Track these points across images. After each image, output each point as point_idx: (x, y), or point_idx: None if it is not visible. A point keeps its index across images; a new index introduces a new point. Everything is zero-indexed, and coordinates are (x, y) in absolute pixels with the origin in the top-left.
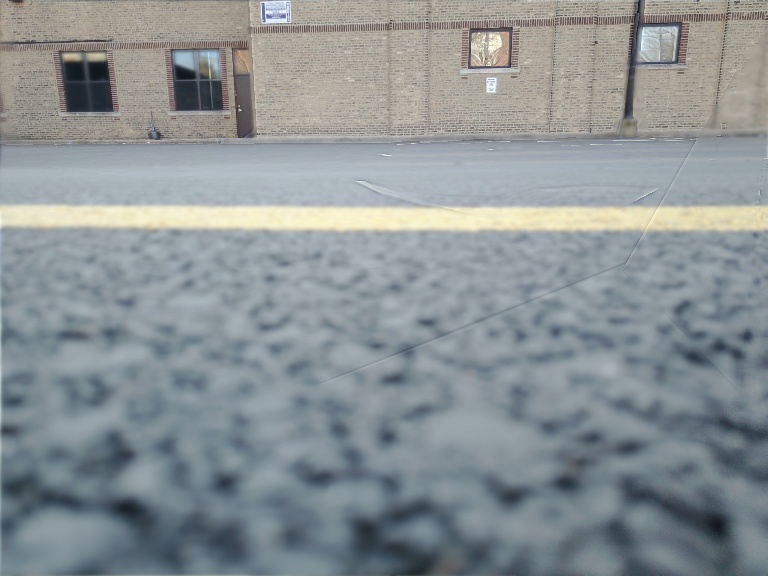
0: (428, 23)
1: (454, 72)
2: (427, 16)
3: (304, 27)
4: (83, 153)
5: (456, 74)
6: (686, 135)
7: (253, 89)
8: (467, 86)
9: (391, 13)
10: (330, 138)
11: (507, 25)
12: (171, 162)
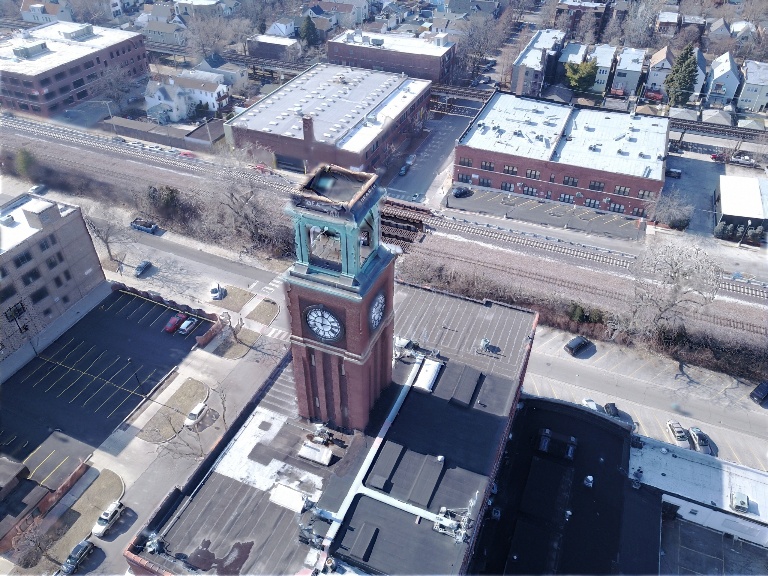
0: None
1: None
2: None
3: None
4: None
5: None
6: (43, 348)
7: None
8: None
9: None
10: None
11: None
12: (44, 406)
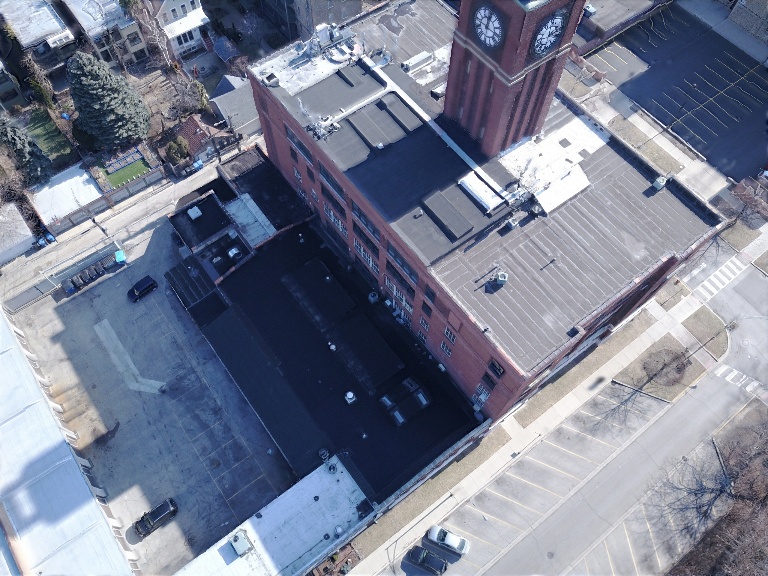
0: (765, 20)
1: (764, 30)
2: (765, 19)
3: (746, 7)
4: None
5: (764, 30)
6: None
7: (732, 11)
8: (765, 33)
9: (760, 15)
10: (728, 37)
11: None
12: (686, 63)
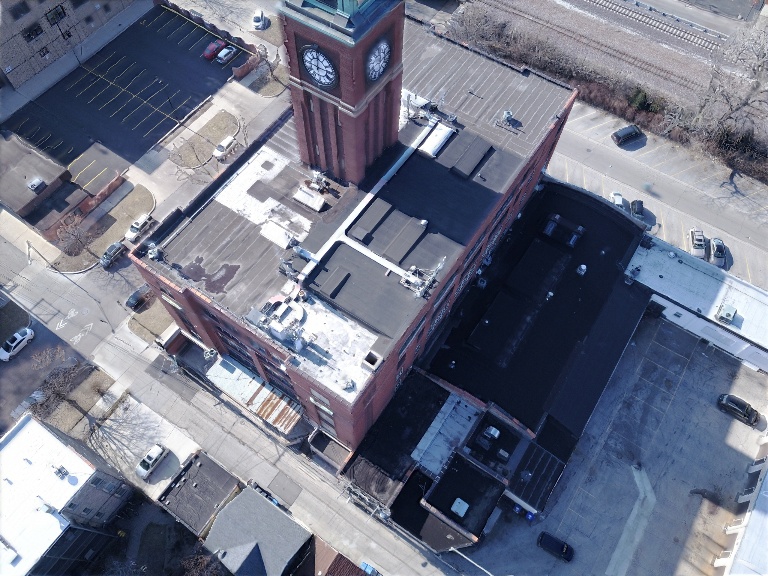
0: None
1: None
2: None
3: None
4: (71, 119)
5: (41, 59)
6: (86, 58)
7: None
8: None
9: None
10: None
11: (44, 47)
12: (86, 117)
